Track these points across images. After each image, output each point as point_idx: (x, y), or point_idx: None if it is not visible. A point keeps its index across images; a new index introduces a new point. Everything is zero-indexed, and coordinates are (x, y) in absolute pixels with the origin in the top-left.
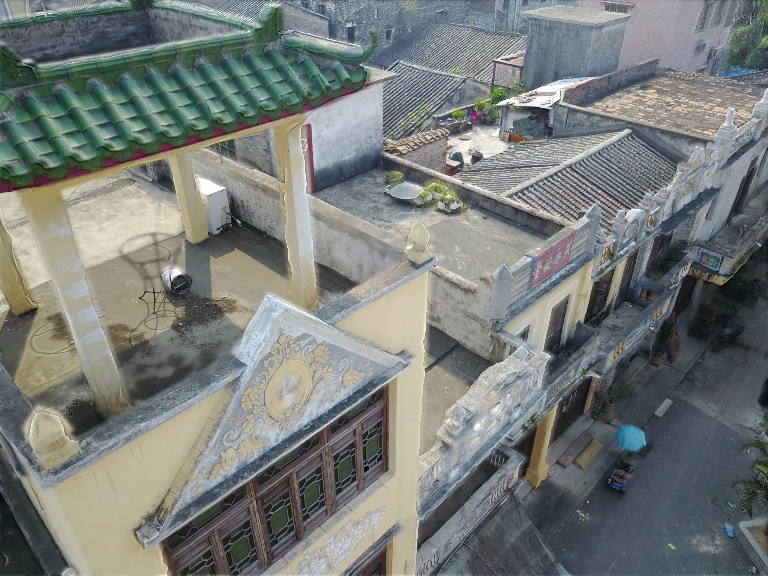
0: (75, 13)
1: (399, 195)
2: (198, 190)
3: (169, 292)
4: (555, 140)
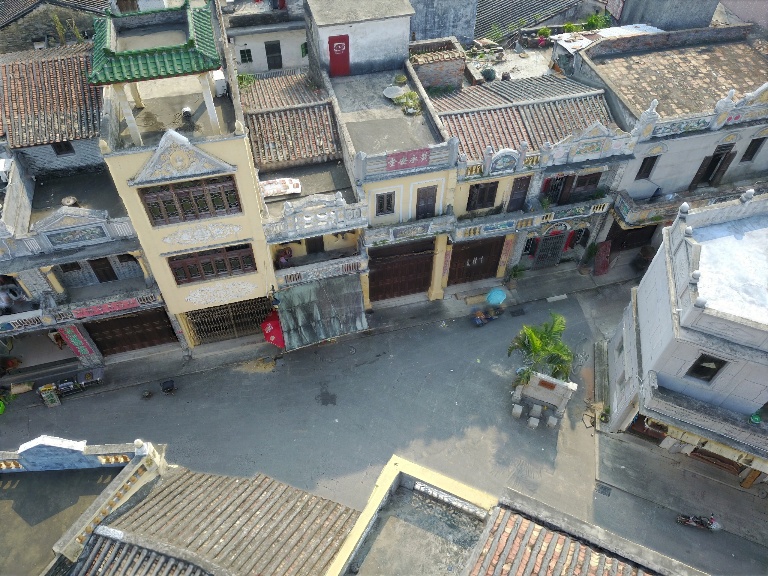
0: None
1: (386, 93)
2: (213, 77)
3: (182, 116)
4: (568, 80)
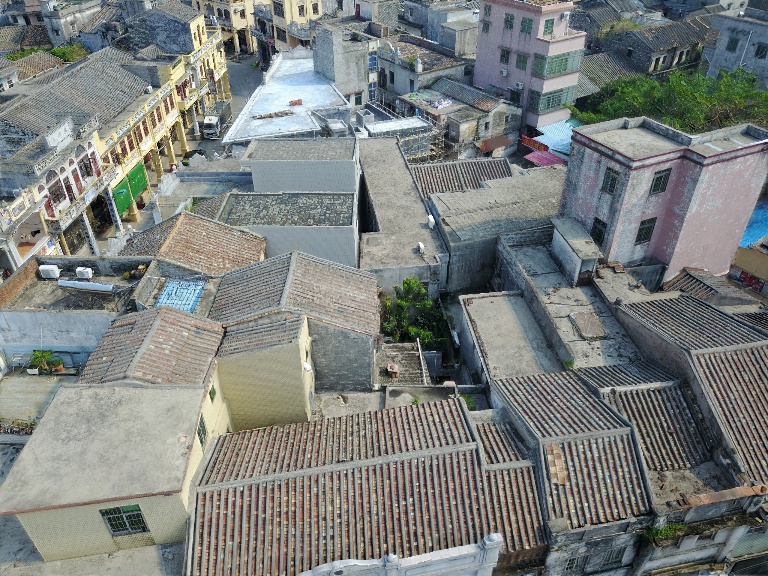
0: None
1: None
2: None
3: None
4: None
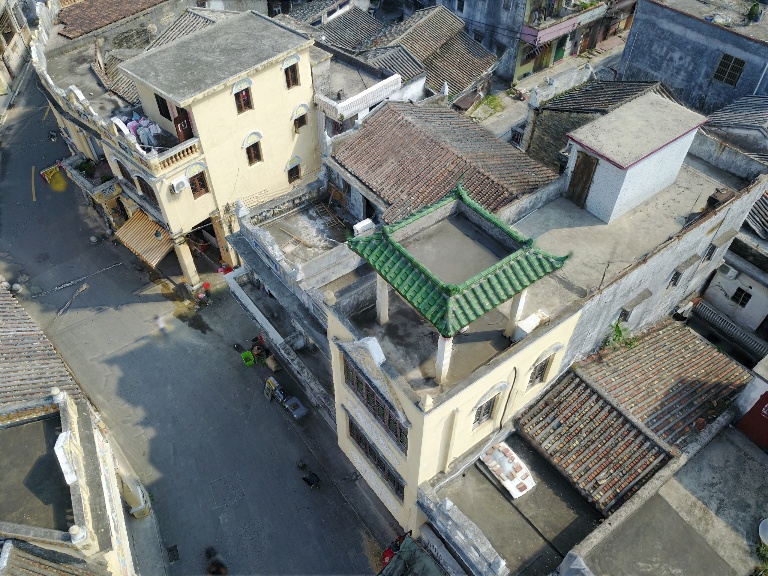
0: (502, 227)
1: (765, 526)
2: (522, 320)
3: None
4: None
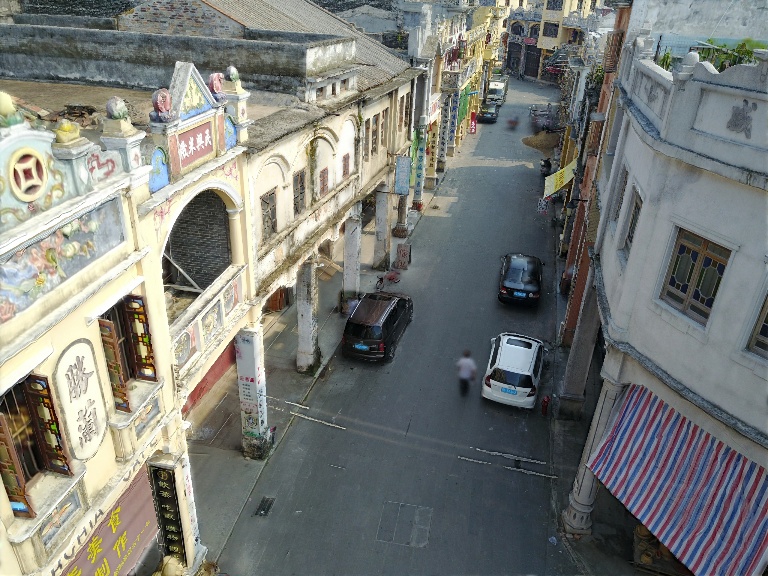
0: None
1: None
2: None
3: None
4: None
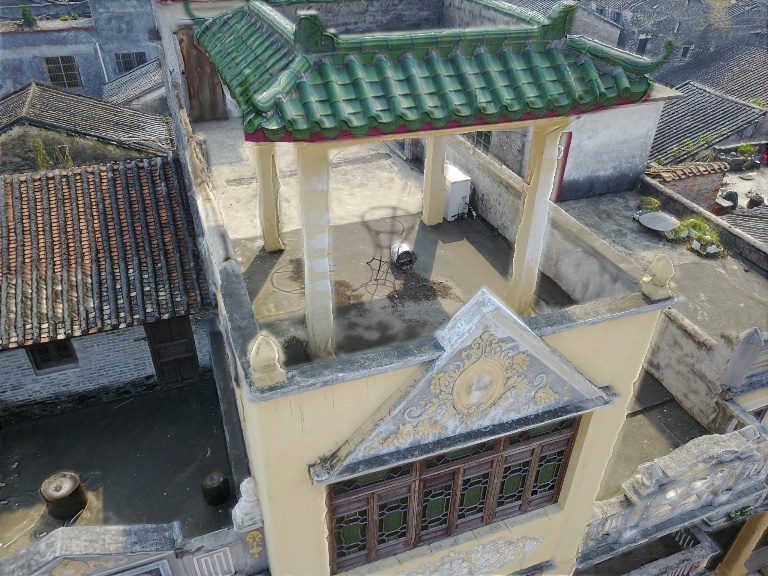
0: None
1: (649, 224)
2: (445, 175)
3: (394, 264)
4: None
